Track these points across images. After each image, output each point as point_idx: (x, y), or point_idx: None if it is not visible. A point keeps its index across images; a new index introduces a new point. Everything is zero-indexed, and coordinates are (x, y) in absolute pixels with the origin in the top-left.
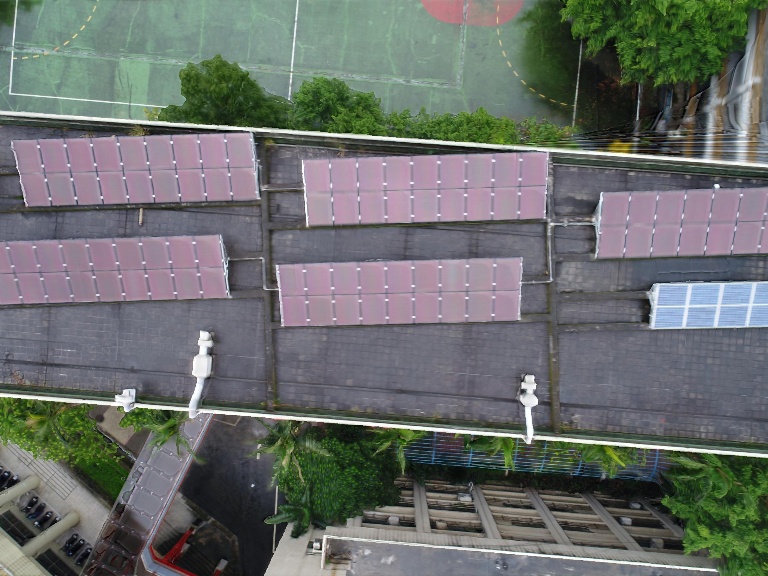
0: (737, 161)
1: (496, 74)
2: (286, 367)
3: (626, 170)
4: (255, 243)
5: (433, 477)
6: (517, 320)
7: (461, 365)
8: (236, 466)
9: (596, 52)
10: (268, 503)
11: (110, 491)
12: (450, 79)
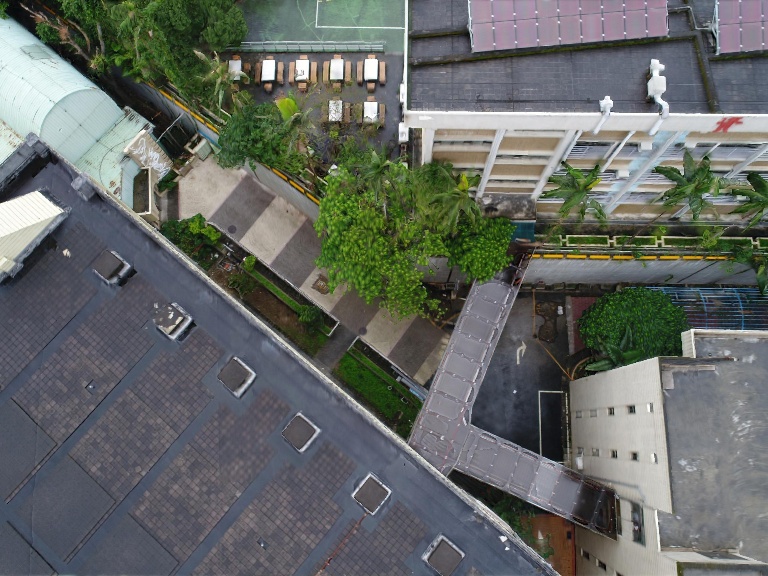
0: None
1: None
2: (722, 90)
3: None
4: (677, 1)
5: None
6: None
7: None
8: (497, 373)
9: None
10: (532, 409)
11: (376, 402)
12: None
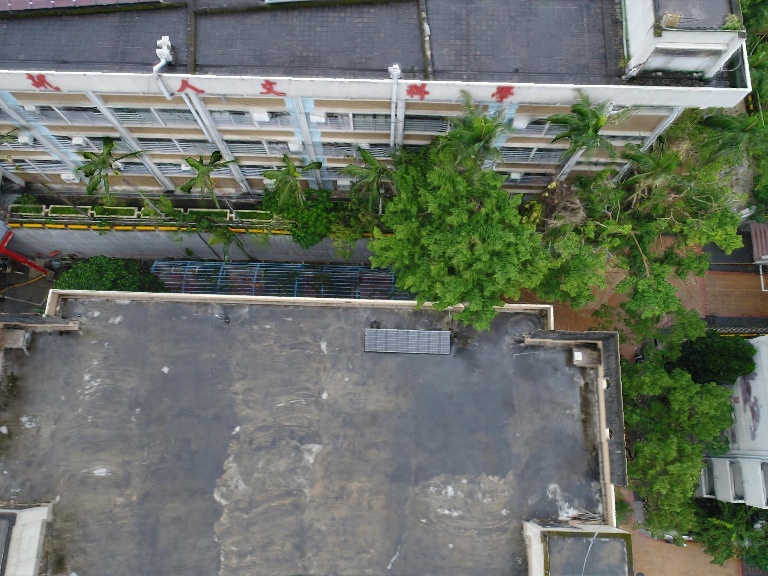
0: None
1: None
2: None
3: None
4: None
5: None
6: (159, 1)
7: (116, 41)
8: None
9: None
10: None
11: None
12: None
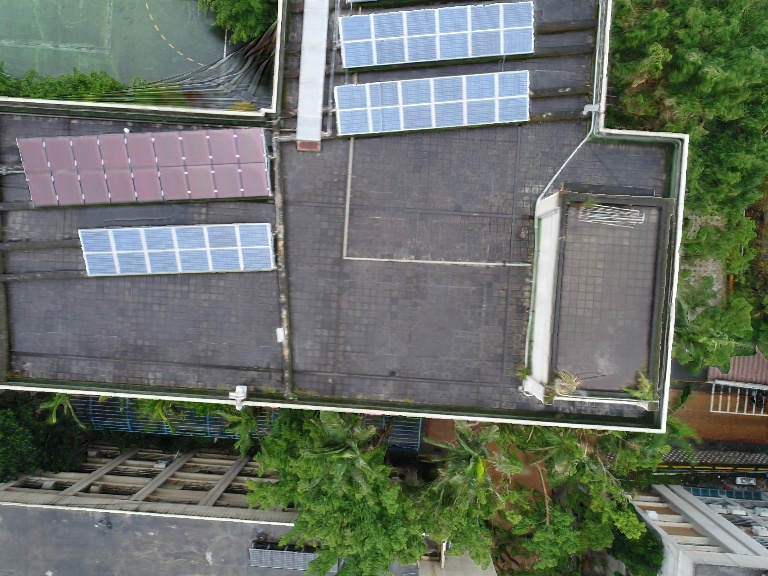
0: (154, 106)
1: (144, 38)
2: None
3: (68, 118)
4: None
5: (156, 447)
6: None
7: None
8: None
9: (206, 12)
10: None
11: None
12: (98, 44)
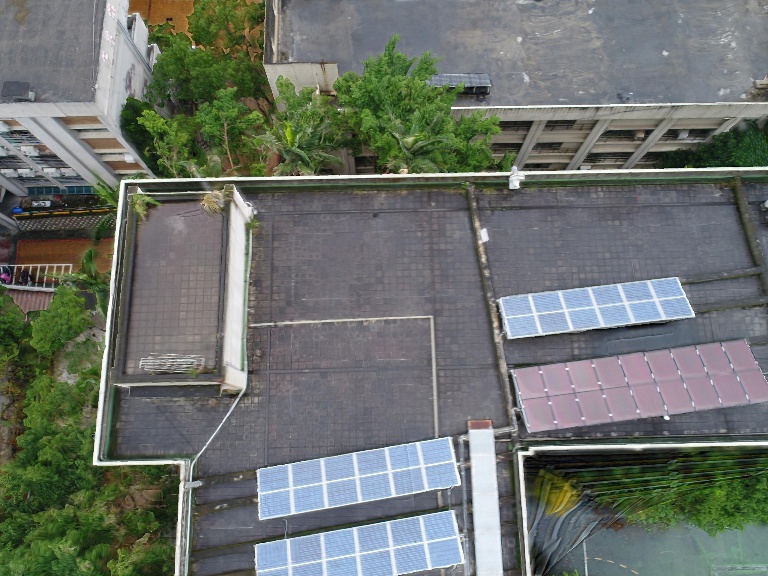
0: None
1: None
2: None
3: None
4: None
5: None
6: None
7: None
8: None
9: None
10: None
11: None
12: (725, 575)
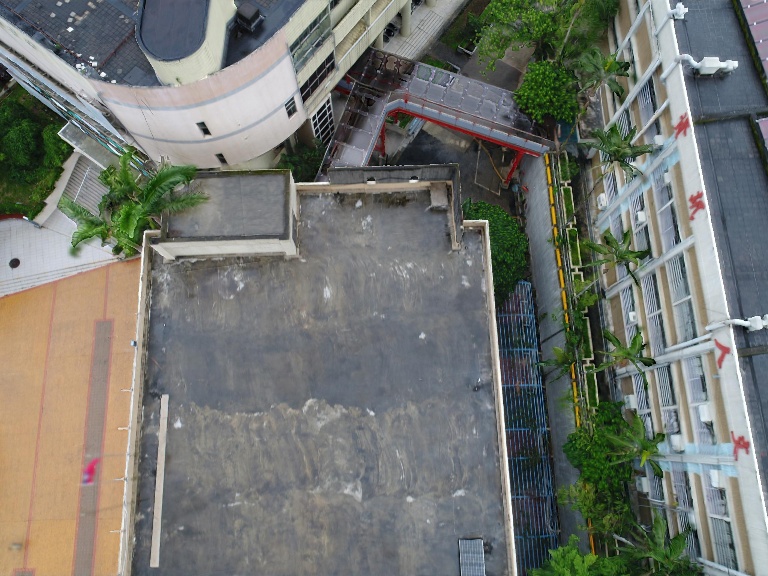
0: None
1: None
2: (719, 129)
3: None
4: None
5: None
6: None
7: (761, 267)
8: None
9: None
10: None
11: None
12: None
